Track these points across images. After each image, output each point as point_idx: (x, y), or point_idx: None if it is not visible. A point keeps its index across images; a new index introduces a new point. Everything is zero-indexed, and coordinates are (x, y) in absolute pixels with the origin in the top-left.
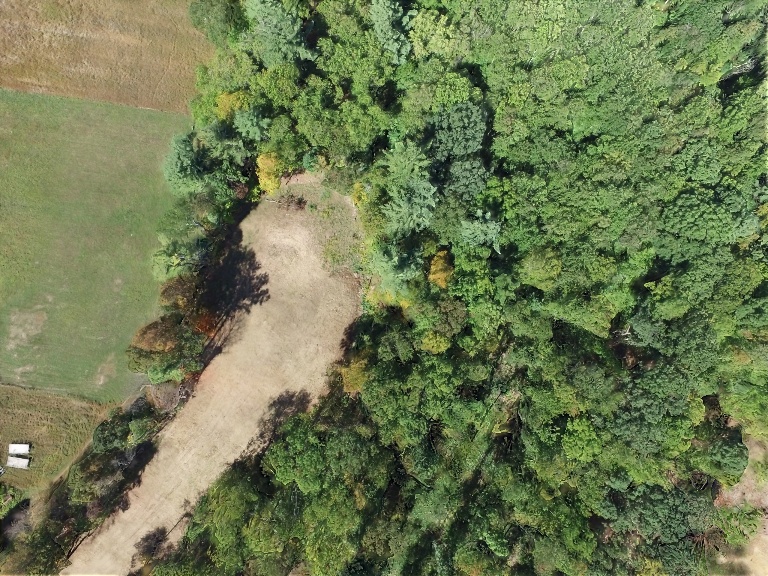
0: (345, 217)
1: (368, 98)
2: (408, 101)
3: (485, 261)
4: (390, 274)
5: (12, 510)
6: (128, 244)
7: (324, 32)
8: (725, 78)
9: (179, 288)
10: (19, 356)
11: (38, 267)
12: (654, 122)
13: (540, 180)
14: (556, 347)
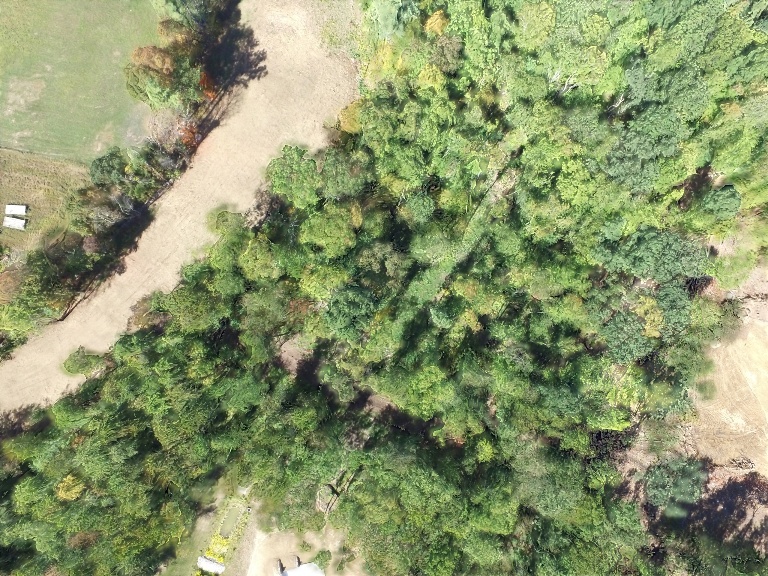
0: (342, 4)
1: None
2: None
3: (480, 3)
4: (387, 1)
5: (8, 269)
6: (127, 19)
7: None
8: None
9: (178, 26)
10: (17, 121)
11: (37, 38)
12: None
13: None
14: None
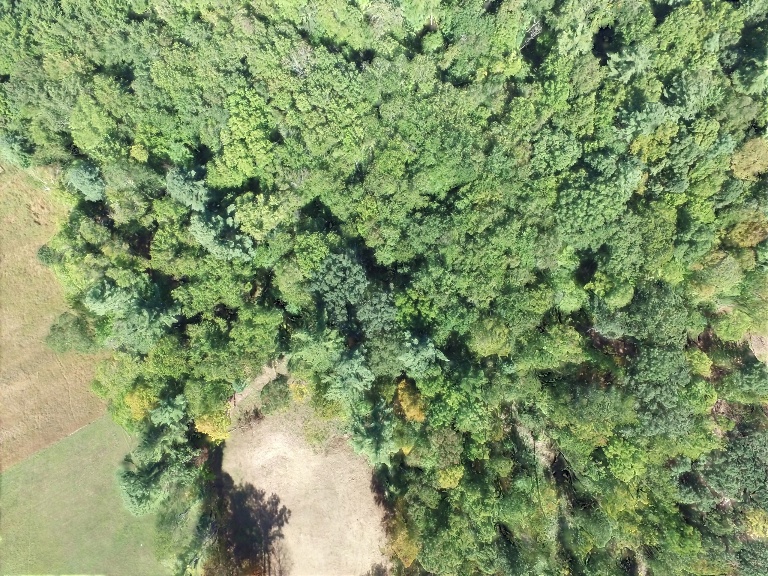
0: None
1: (247, 313)
2: (282, 287)
3: (441, 376)
4: (372, 454)
5: None
6: (144, 555)
7: (171, 281)
8: (525, 45)
9: None
10: None
11: None
12: (494, 151)
13: (437, 270)
14: (550, 391)
